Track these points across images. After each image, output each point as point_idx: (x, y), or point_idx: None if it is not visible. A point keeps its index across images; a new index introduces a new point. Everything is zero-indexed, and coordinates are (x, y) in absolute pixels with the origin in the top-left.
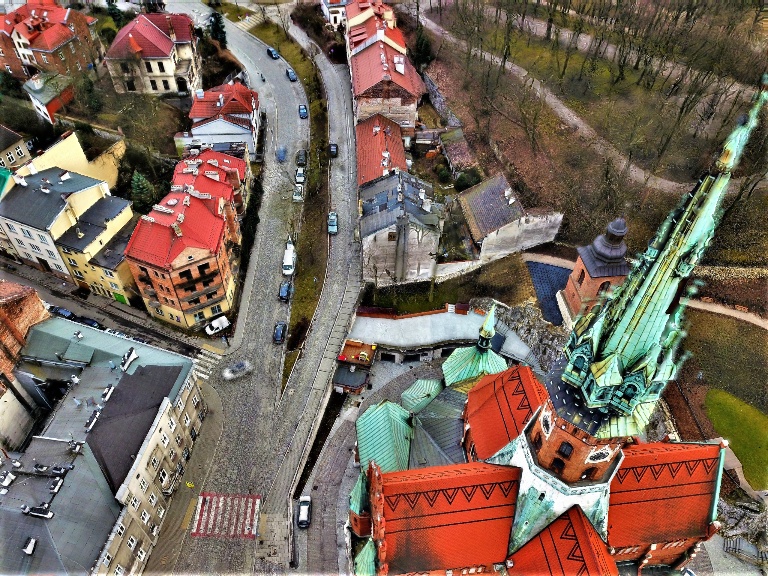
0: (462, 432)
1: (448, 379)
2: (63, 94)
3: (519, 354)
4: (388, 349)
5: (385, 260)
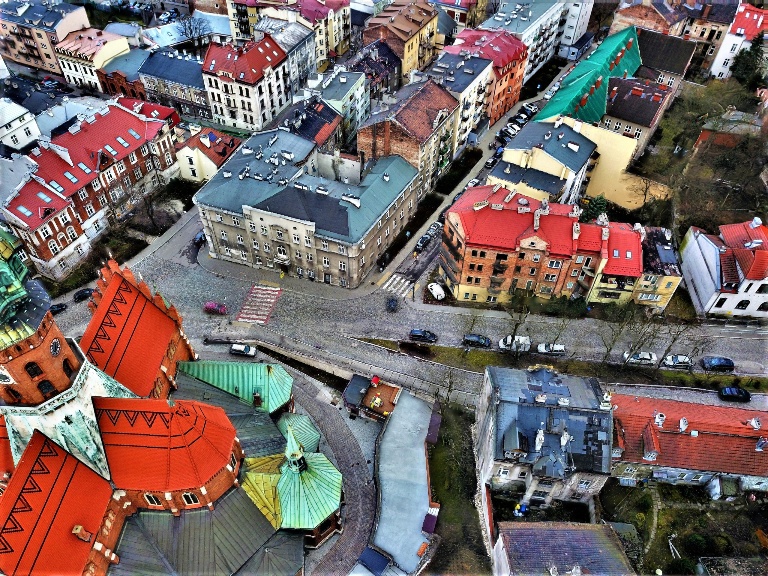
0: None
1: None
2: (727, 136)
3: None
4: None
5: None
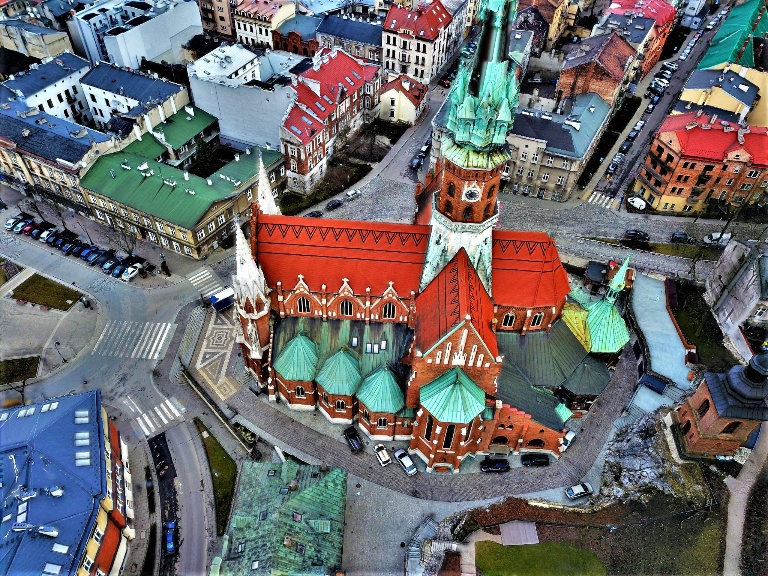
0: None
1: None
2: None
3: (641, 400)
4: None
5: (725, 278)
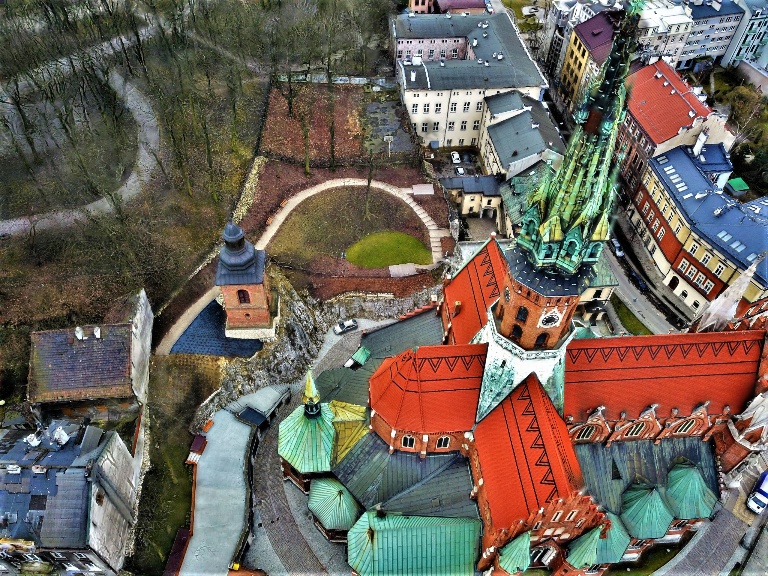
0: (409, 454)
1: (322, 467)
2: None
3: (273, 398)
4: (240, 548)
5: (113, 525)
